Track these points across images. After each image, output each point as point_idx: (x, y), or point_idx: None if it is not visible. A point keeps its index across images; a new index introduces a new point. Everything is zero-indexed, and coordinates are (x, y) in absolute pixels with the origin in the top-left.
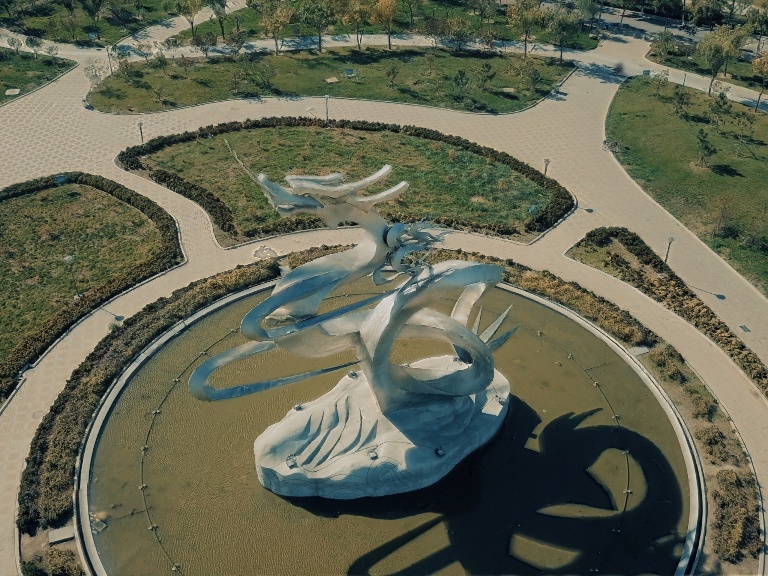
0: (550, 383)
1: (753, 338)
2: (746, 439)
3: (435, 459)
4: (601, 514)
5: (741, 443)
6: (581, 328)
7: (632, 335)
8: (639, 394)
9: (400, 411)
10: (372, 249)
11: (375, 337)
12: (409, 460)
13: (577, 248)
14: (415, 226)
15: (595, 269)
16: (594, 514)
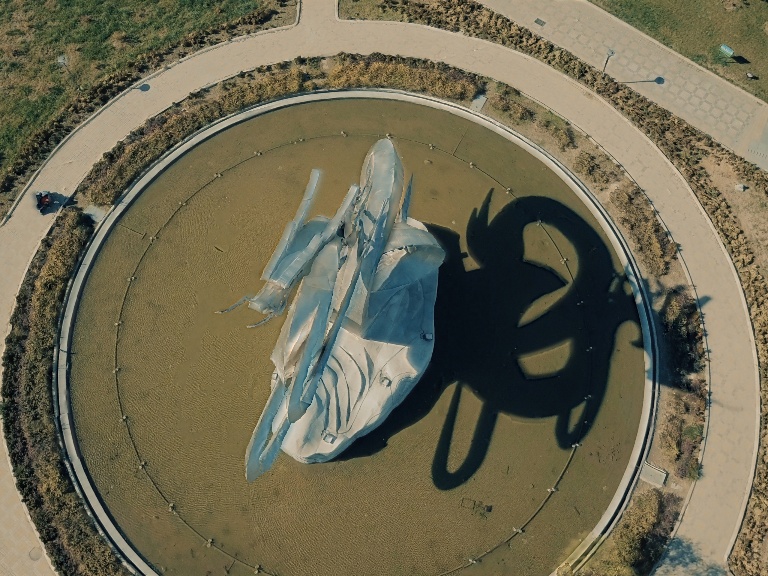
0: (437, 189)
1: (552, 30)
2: (609, 149)
3: (429, 346)
4: (560, 295)
5: (609, 156)
6: (417, 106)
7: (466, 91)
8: (509, 153)
9: (373, 325)
10: (332, 251)
11: (358, 309)
12: (415, 365)
13: (344, 2)
14: (363, 206)
15: (378, 21)
16: (556, 299)
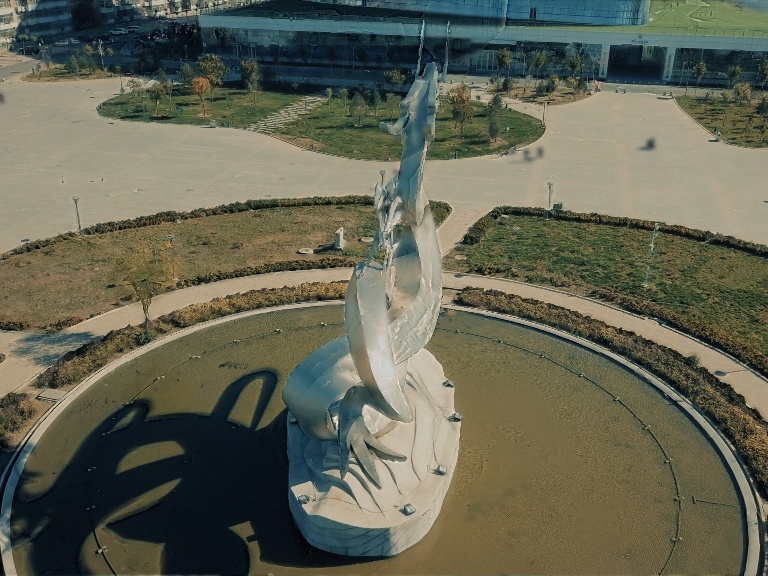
0: None
1: None
2: None
3: None
4: (117, 515)
5: None
6: None
7: None
8: None
9: None
10: None
11: None
12: None
13: None
14: None
15: None
16: (125, 511)
